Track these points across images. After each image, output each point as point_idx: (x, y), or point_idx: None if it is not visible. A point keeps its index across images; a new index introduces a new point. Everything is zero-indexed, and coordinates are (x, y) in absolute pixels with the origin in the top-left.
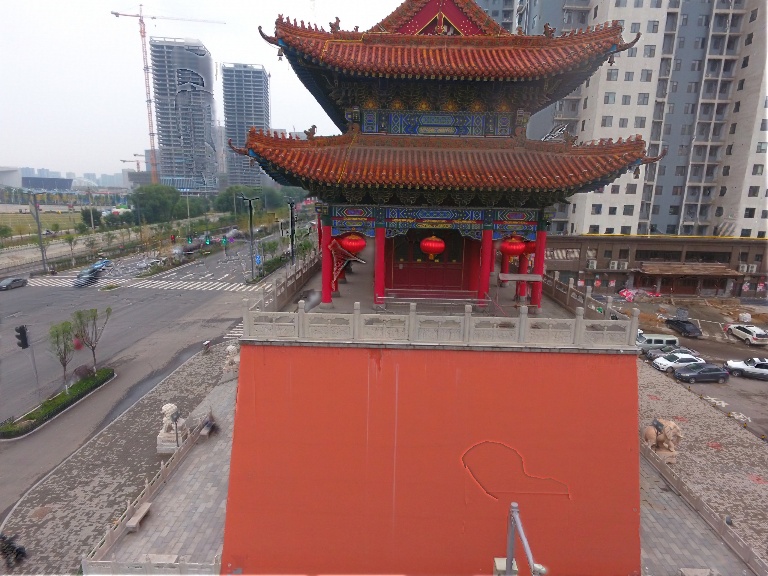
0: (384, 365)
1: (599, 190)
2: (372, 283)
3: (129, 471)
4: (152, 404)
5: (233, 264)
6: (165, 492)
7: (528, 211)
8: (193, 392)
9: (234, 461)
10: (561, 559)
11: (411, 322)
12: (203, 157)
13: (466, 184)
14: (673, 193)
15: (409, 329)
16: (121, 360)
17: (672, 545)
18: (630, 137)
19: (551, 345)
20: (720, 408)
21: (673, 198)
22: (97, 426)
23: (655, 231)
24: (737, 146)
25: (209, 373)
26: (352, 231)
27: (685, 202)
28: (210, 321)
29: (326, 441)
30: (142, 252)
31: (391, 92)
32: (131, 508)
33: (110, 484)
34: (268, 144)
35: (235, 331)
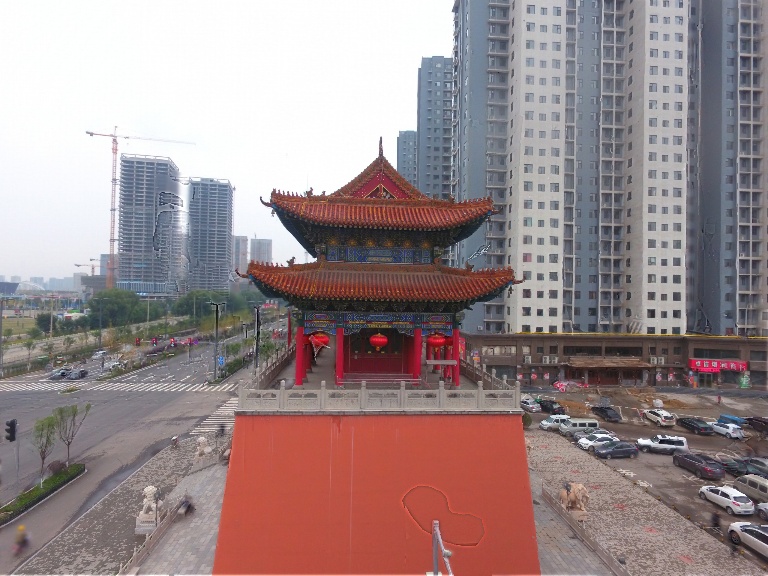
0: (343, 428)
1: (527, 295)
2: (333, 372)
3: (110, 550)
4: (125, 494)
5: (195, 365)
6: (149, 561)
7: (445, 315)
8: (164, 482)
9: (224, 511)
10: None
11: (362, 395)
12: (178, 267)
13: (399, 297)
14: (589, 297)
15: (361, 400)
16: (90, 457)
17: (572, 575)
18: None
19: (462, 409)
20: (629, 478)
21: (590, 301)
22: (73, 515)
23: (577, 329)
24: (633, 260)
25: (178, 465)
26: (319, 330)
27: (600, 305)
28: (175, 419)
29: (298, 491)
30: (105, 355)
31: (348, 234)
32: (123, 571)
33: (93, 562)
34: (262, 271)
35: (200, 428)
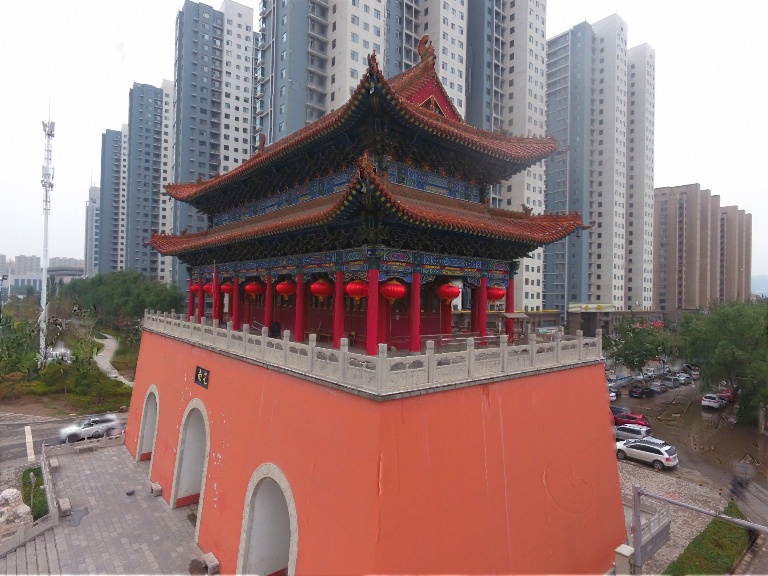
0: (492, 400)
1: None
2: None
3: None
4: None
5: None
6: None
7: (505, 263)
8: None
9: (380, 567)
10: (596, 548)
11: (505, 353)
12: None
13: (503, 234)
14: None
15: (504, 360)
16: None
17: None
18: (571, 211)
19: (572, 362)
20: None
21: None
22: None
23: None
24: None
25: None
26: (395, 276)
27: None
28: None
29: (459, 500)
30: None
31: None
32: None
33: None
34: None
35: None
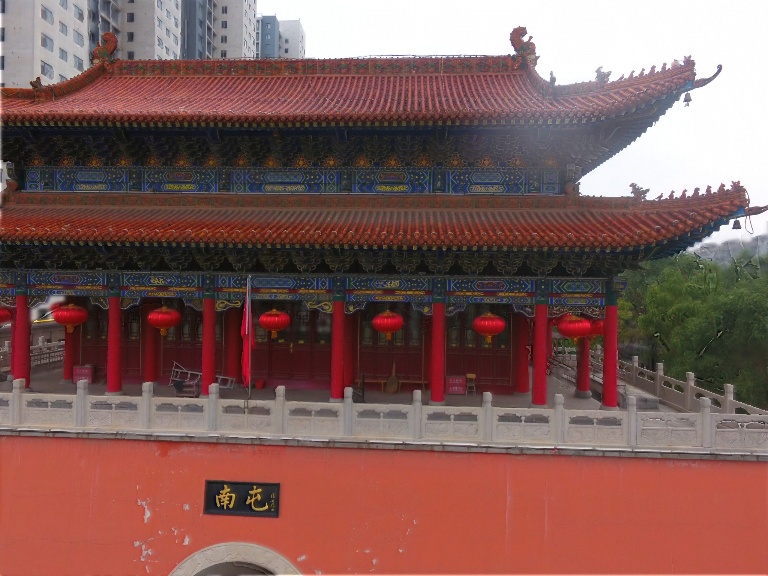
0: None
1: None
2: (468, 389)
3: None
4: None
5: None
6: None
7: None
8: None
9: None
10: None
11: None
12: None
13: None
14: None
15: None
16: None
17: None
18: None
19: None
20: None
21: None
22: None
23: None
24: None
25: None
26: None
27: None
28: None
29: None
30: None
31: None
32: None
33: None
34: None
35: None
